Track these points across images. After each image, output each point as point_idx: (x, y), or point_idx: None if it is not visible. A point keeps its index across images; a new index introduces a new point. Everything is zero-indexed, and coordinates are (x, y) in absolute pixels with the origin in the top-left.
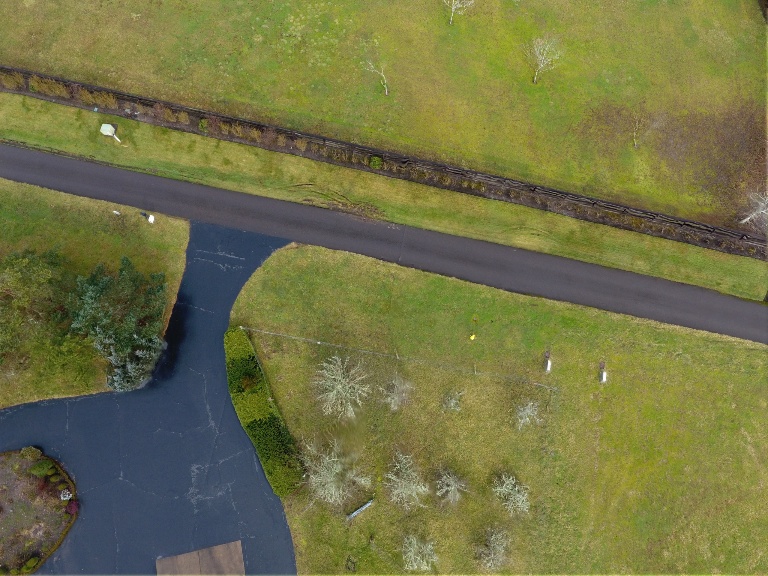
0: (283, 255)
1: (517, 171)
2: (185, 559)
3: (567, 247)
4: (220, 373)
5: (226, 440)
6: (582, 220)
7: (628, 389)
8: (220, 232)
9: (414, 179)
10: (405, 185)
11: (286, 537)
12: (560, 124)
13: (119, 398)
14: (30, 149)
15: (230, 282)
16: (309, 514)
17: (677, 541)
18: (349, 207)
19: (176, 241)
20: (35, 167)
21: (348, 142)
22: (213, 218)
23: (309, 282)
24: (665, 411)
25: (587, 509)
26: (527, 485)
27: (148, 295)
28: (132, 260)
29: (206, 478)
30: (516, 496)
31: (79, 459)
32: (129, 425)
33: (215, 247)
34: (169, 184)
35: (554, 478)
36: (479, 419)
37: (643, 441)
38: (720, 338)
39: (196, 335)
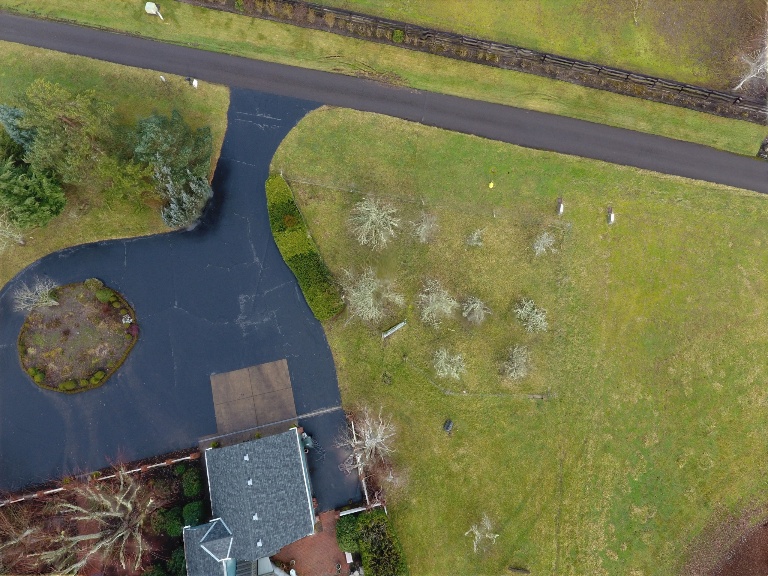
0: (316, 116)
1: (527, 45)
2: (237, 375)
3: (575, 110)
4: (262, 217)
5: (270, 274)
6: (588, 87)
7: (634, 230)
8: (258, 96)
9: (433, 52)
10: (425, 57)
11: (327, 355)
12: (566, 4)
13: (171, 239)
14: (81, 26)
15: (268, 139)
16: (347, 336)
17: (681, 360)
18: (375, 75)
19: (218, 104)
20: (86, 41)
21: (373, 16)
22: (251, 84)
23: (340, 139)
24: (668, 249)
25: (599, 333)
26: (545, 308)
27: (197, 141)
28: (180, 114)
29: (253, 306)
30: (535, 317)
31: (137, 290)
32: (181, 262)
33: (254, 109)
34: (209, 55)
35: (569, 306)
36: (499, 256)
37: (649, 275)
38: (717, 187)
39: (239, 185)
